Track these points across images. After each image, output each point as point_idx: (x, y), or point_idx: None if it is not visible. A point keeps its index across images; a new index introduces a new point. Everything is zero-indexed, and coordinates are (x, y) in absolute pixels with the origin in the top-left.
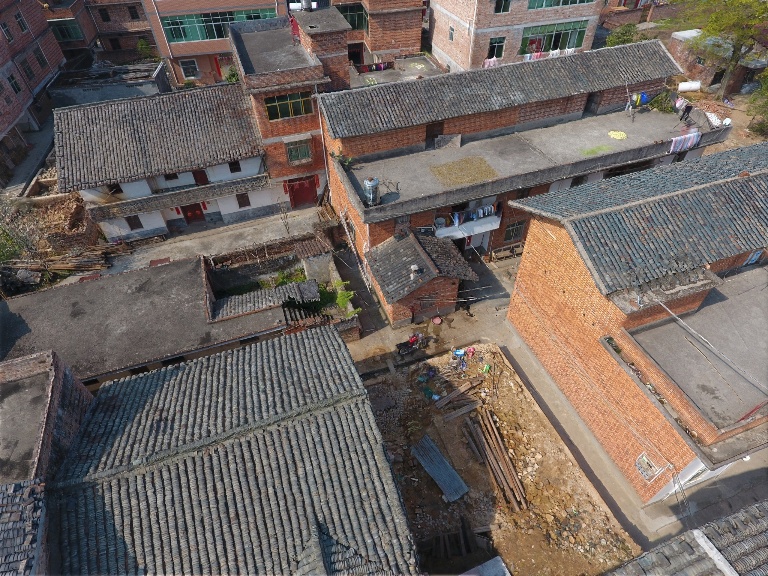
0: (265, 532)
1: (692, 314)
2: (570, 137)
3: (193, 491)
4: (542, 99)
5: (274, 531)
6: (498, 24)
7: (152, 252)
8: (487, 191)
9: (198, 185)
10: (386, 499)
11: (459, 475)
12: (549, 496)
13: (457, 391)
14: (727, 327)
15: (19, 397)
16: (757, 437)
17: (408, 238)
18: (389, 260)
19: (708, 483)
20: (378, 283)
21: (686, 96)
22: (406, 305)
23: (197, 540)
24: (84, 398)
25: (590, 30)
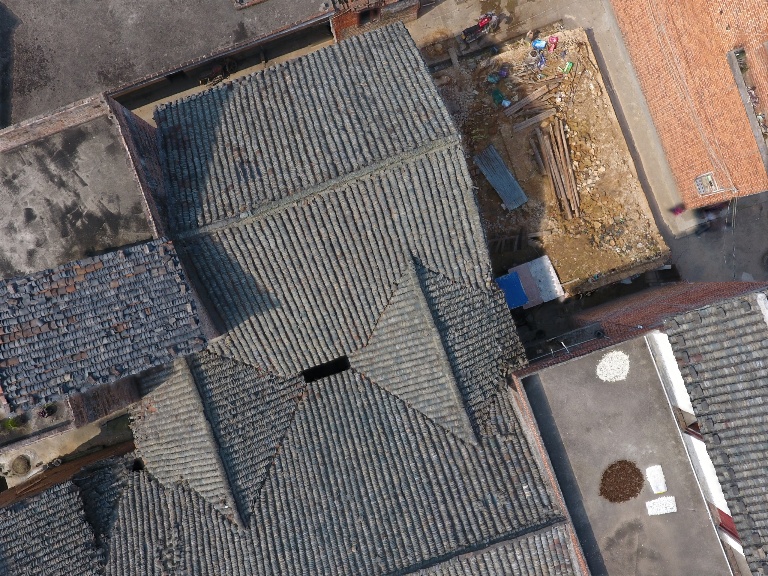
0: (368, 265)
1: None
2: None
3: (300, 236)
4: None
5: (376, 264)
6: None
7: None
8: None
9: None
10: (472, 236)
11: (520, 186)
12: (602, 206)
13: (531, 97)
14: None
15: (91, 146)
16: None
17: None
18: None
19: None
20: None
21: None
22: None
23: (312, 272)
24: (150, 135)
25: None
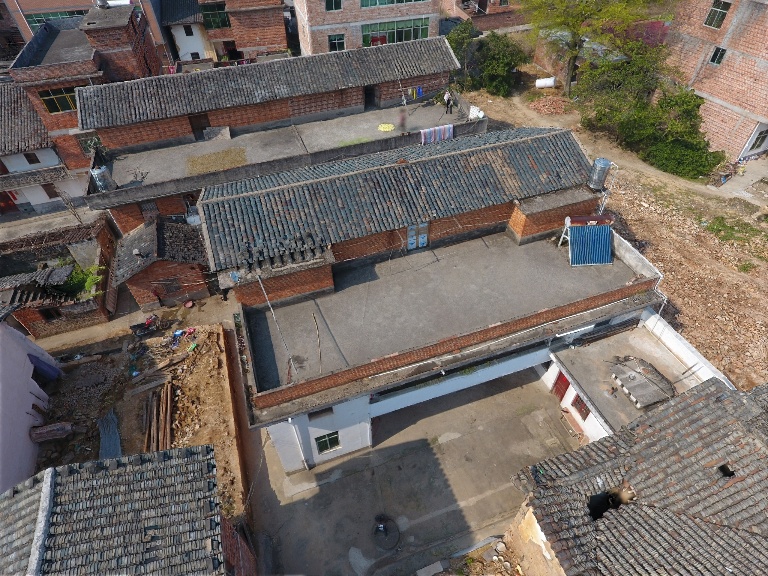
0: None
1: (332, 292)
2: (340, 129)
3: None
4: (306, 93)
5: None
6: (333, 21)
7: None
8: (222, 180)
9: None
10: None
11: (120, 444)
12: None
13: (155, 368)
14: (358, 304)
15: None
16: (311, 402)
17: (154, 225)
18: (132, 246)
19: (362, 453)
20: None
21: (537, 92)
22: (146, 289)
23: None
24: None
25: (433, 27)
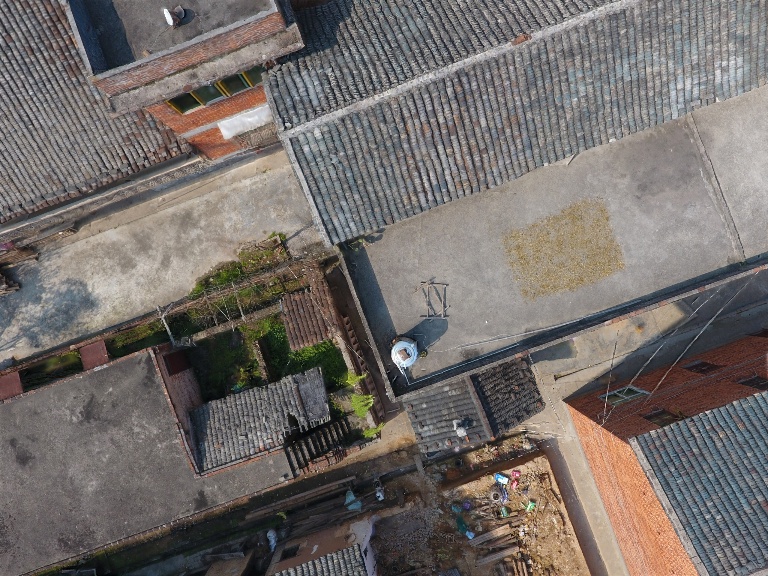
0: None
1: None
2: None
3: None
4: None
5: None
6: None
7: (66, 256)
8: None
9: (91, 194)
10: None
11: None
12: None
13: (494, 533)
14: None
15: None
16: None
17: None
18: None
19: None
20: (408, 416)
21: None
22: None
23: None
24: None
25: None
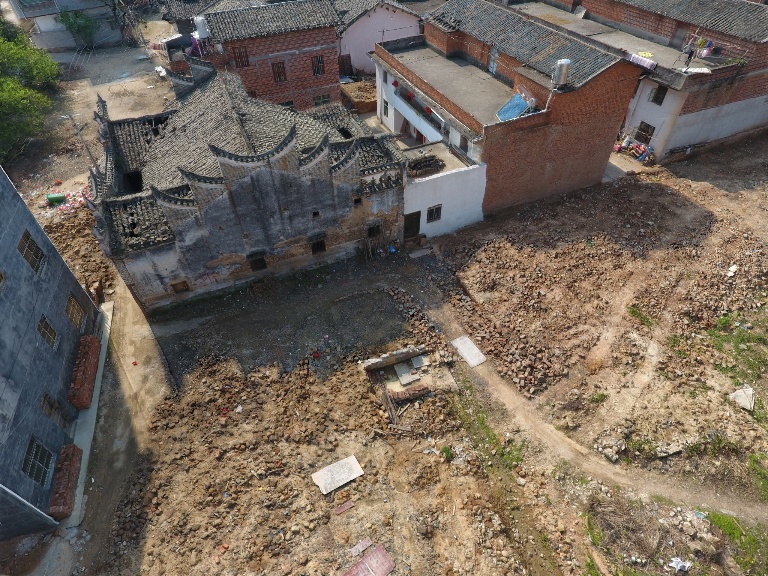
0: None
1: (445, 57)
2: (626, 42)
3: None
4: (634, 5)
5: None
6: None
7: None
8: None
9: None
10: None
11: None
12: None
13: None
14: (440, 64)
15: None
16: None
17: None
18: None
19: None
20: None
21: None
22: None
23: None
24: None
25: None
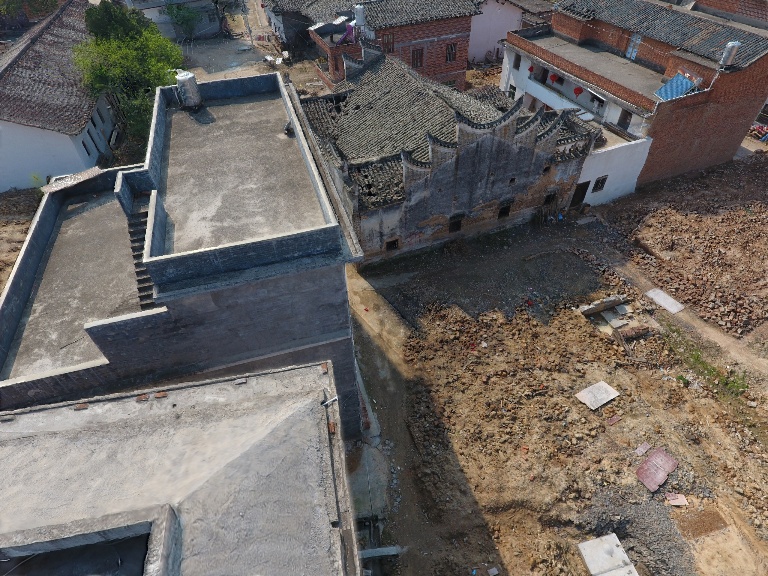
0: None
1: None
2: None
3: None
4: None
5: None
6: None
7: None
8: None
9: None
10: None
11: None
12: None
13: None
14: None
15: None
16: None
17: None
18: None
19: None
20: None
21: None
22: None
23: None
24: None
25: None
